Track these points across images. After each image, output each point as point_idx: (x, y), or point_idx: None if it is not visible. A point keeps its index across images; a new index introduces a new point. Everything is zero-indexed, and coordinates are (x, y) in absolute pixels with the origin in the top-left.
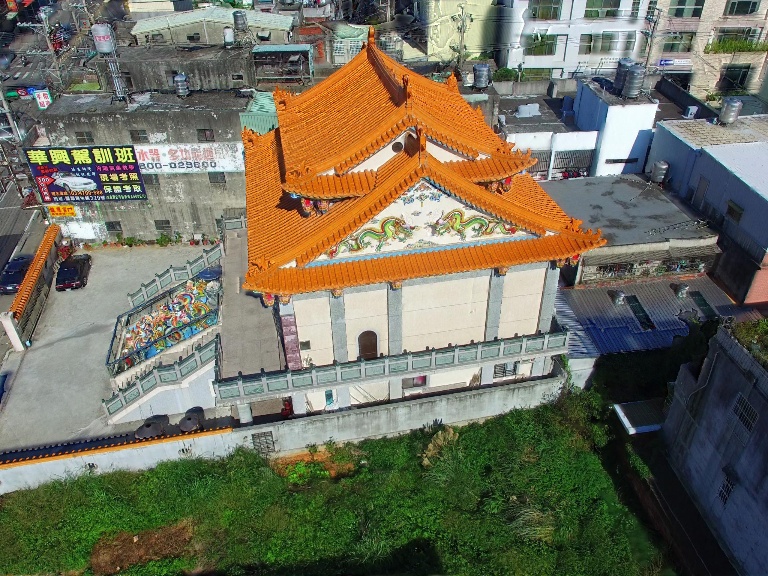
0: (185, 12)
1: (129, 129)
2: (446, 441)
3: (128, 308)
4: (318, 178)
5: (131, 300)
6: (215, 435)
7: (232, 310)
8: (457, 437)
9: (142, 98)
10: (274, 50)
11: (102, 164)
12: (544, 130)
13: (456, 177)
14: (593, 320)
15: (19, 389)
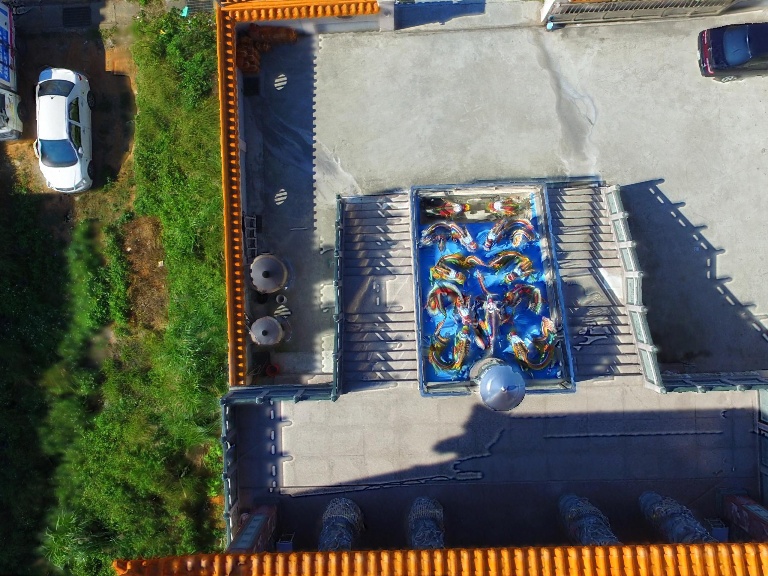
0: None
1: None
2: None
3: (626, 176)
4: None
5: (613, 189)
6: None
7: (459, 405)
8: None
9: None
10: None
11: None
12: None
13: None
14: None
15: (443, 44)
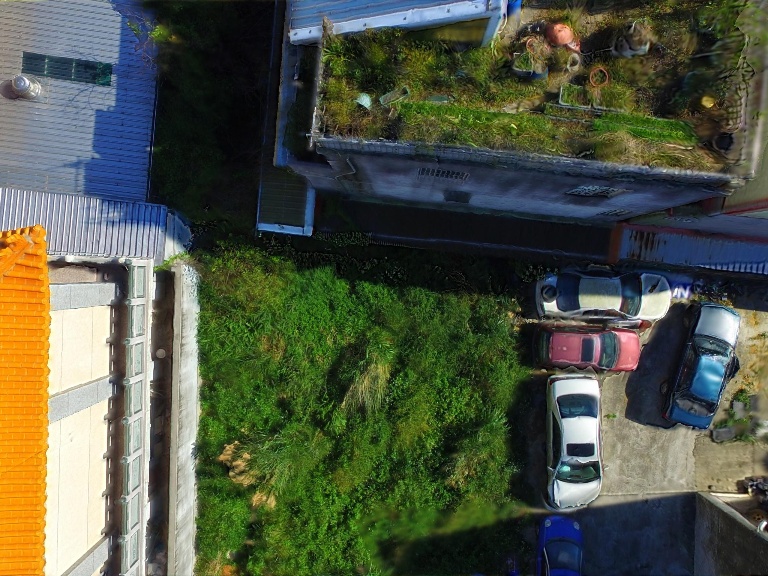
0: None
1: None
2: (244, 466)
3: None
4: None
5: None
6: None
7: None
8: (249, 458)
9: None
10: None
11: None
12: None
13: None
14: (69, 160)
15: None
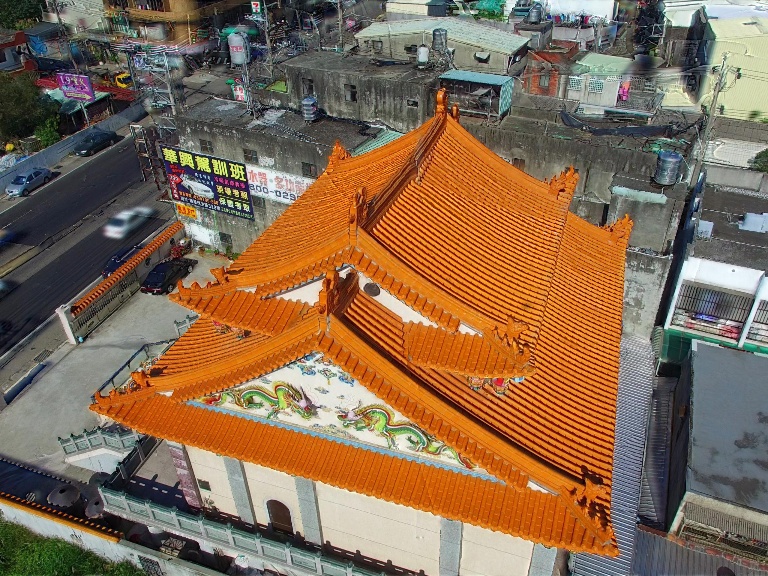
0: (417, 20)
1: (243, 147)
2: None
3: None
4: (236, 293)
5: (177, 328)
6: (101, 538)
7: None
8: None
9: (273, 115)
10: (462, 79)
11: (219, 176)
12: (767, 260)
13: (379, 362)
14: None
15: (40, 385)
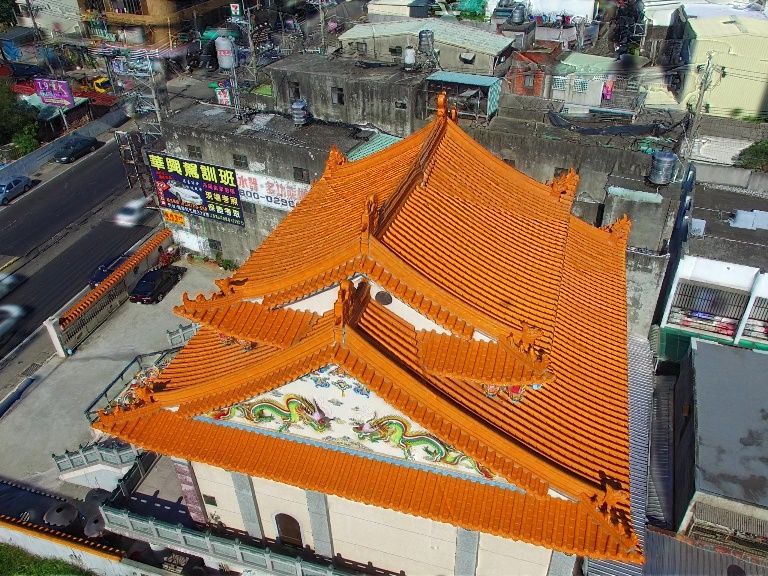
0: (401, 21)
1: (232, 152)
2: None
3: None
4: (242, 304)
5: (170, 337)
6: (102, 557)
7: None
8: None
9: (261, 120)
10: (450, 80)
11: (208, 182)
12: (759, 256)
13: (395, 372)
14: None
15: (30, 400)
